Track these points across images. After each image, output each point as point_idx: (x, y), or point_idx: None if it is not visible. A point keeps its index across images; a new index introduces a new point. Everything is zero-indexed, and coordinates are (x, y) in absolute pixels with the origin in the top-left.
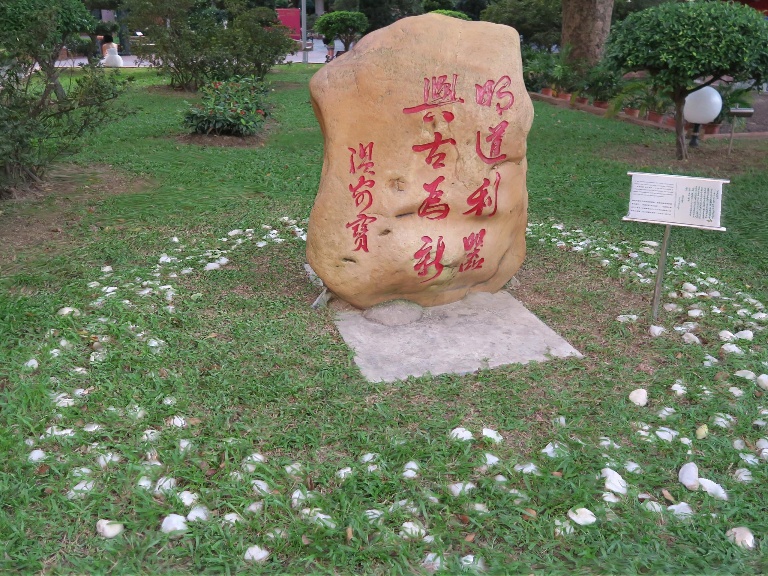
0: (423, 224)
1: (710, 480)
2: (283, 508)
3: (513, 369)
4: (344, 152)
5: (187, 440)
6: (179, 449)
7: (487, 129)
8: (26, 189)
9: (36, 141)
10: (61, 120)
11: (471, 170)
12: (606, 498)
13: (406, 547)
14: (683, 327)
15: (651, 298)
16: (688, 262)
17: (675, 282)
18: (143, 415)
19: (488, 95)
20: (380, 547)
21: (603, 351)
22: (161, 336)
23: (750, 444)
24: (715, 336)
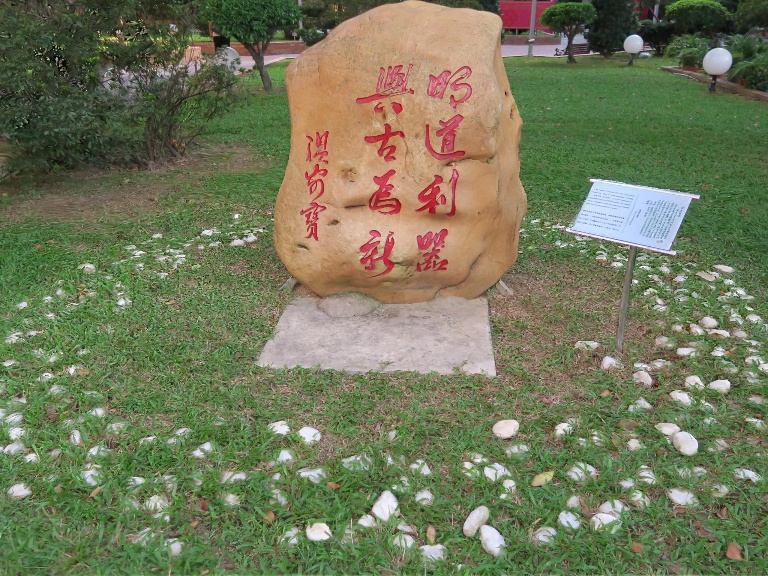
0: (374, 218)
1: (496, 530)
2: (73, 458)
3: (404, 376)
4: (303, 140)
5: (57, 386)
6: (47, 392)
7: (437, 123)
8: (164, 163)
9: (145, 120)
10: (202, 103)
11: (420, 165)
12: (361, 520)
13: (131, 516)
14: (648, 364)
15: (648, 328)
16: (749, 294)
17: (697, 314)
18: (55, 360)
19: (442, 87)
20: None
21: (518, 374)
22: (132, 297)
23: (584, 503)
24: (680, 380)
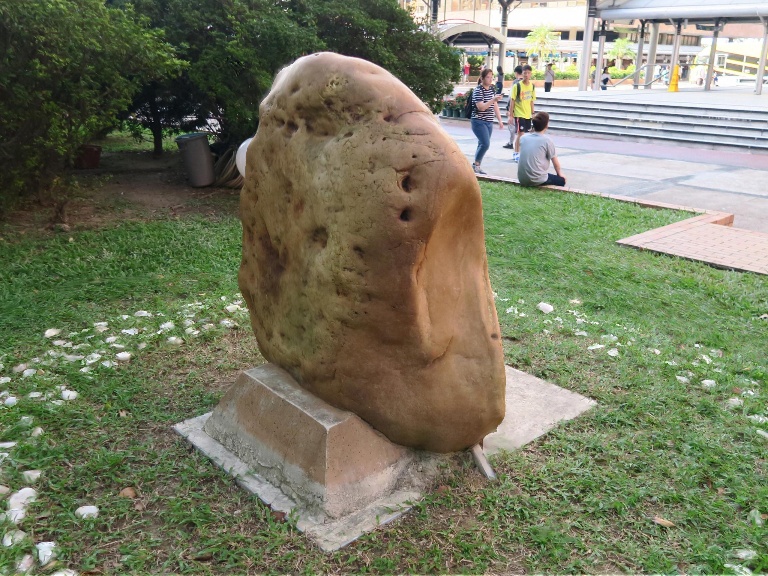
0: None
1: None
2: None
3: None
4: None
5: None
6: None
7: None
8: None
9: None
10: None
11: None
12: (597, 323)
13: None
14: None
15: None
16: None
17: None
18: None
19: None
20: (734, 365)
21: None
22: None
23: None
24: None
